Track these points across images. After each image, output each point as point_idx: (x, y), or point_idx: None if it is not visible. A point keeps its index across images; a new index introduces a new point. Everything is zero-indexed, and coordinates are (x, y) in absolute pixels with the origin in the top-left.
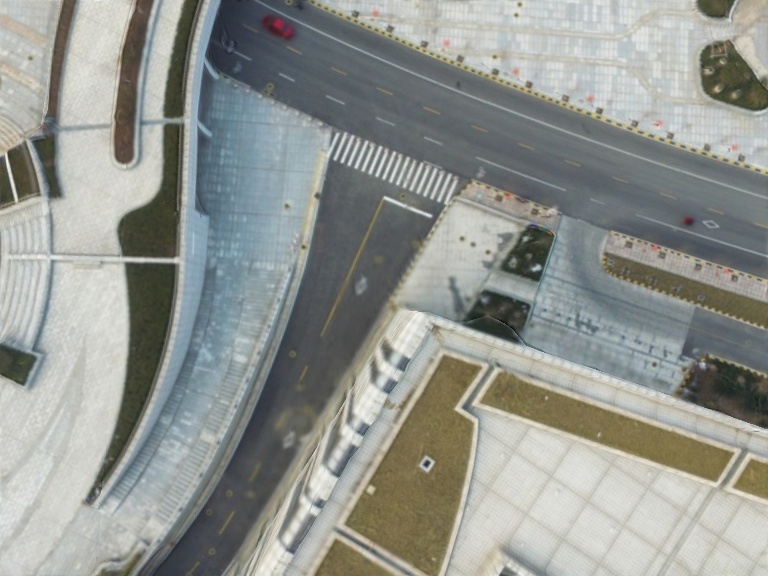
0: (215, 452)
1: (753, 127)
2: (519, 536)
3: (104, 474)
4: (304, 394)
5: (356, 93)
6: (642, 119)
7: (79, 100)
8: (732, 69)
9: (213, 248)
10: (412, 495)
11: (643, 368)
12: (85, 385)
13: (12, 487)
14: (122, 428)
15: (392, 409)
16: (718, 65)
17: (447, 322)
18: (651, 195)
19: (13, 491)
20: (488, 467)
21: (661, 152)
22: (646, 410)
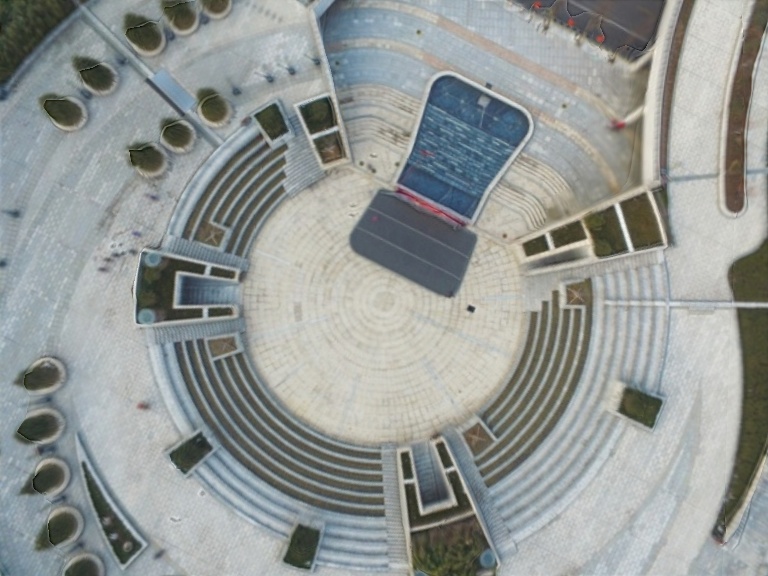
0: None
1: None
2: None
3: (726, 512)
4: None
5: None
6: None
7: (686, 151)
8: None
9: None
10: None
11: None
12: (702, 427)
13: (639, 526)
14: (742, 468)
15: None
16: None
17: None
18: None
19: (640, 529)
20: None
21: None
22: None
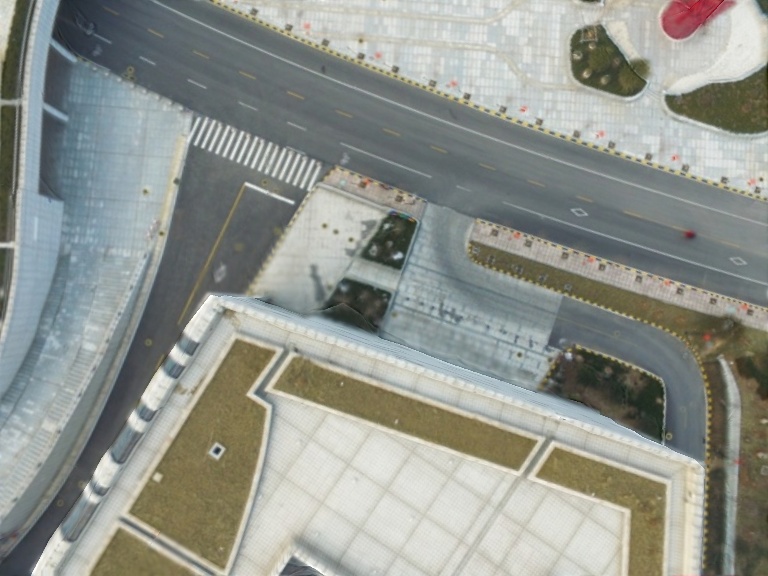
0: (56, 441)
1: (624, 113)
2: (314, 525)
3: None
4: None
5: (218, 77)
6: (510, 105)
7: None
8: (600, 54)
9: (68, 234)
10: (201, 483)
11: (508, 358)
12: None
13: None
14: None
15: (184, 394)
16: (586, 50)
17: (238, 305)
18: (519, 182)
19: None
20: (283, 454)
21: (529, 138)
22: (448, 397)
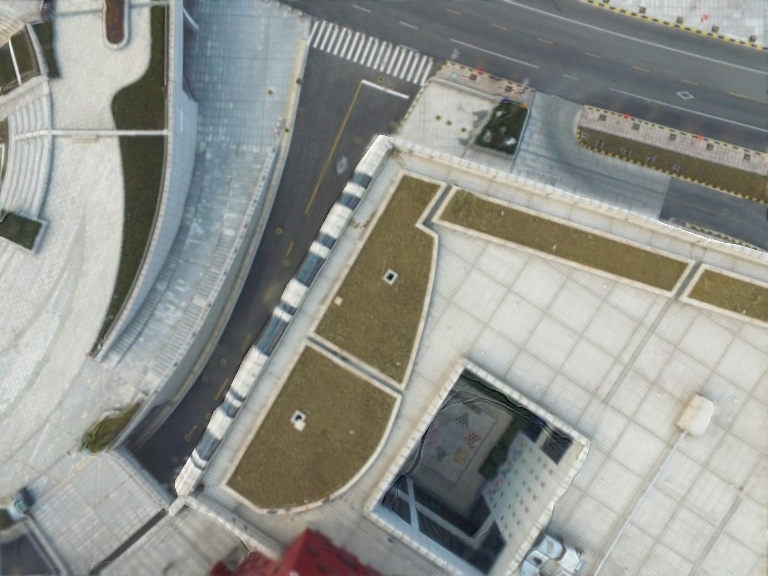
0: (207, 314)
1: None
2: (480, 345)
3: (105, 331)
4: (291, 268)
5: None
6: None
7: None
8: None
9: (202, 133)
10: (377, 305)
11: None
12: (86, 250)
13: (23, 344)
14: (120, 288)
15: (357, 228)
16: None
17: (406, 142)
18: (624, 69)
19: (24, 347)
20: (449, 281)
21: (633, 26)
22: (600, 225)
